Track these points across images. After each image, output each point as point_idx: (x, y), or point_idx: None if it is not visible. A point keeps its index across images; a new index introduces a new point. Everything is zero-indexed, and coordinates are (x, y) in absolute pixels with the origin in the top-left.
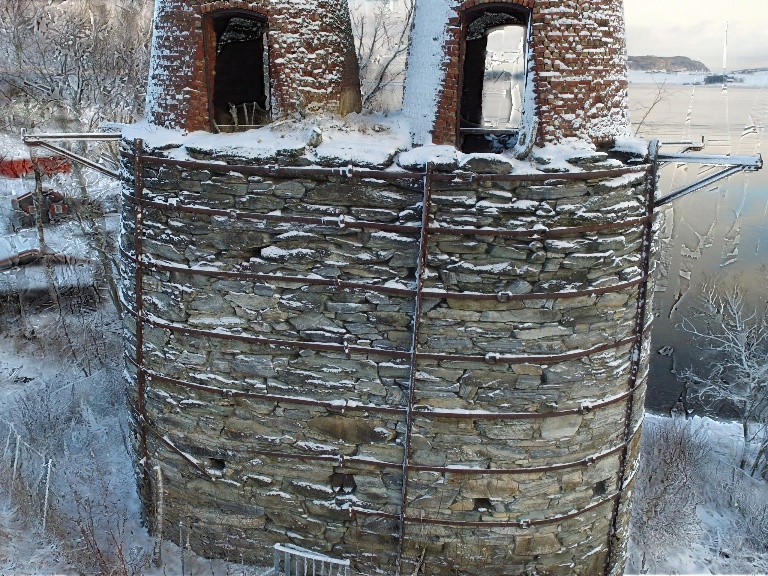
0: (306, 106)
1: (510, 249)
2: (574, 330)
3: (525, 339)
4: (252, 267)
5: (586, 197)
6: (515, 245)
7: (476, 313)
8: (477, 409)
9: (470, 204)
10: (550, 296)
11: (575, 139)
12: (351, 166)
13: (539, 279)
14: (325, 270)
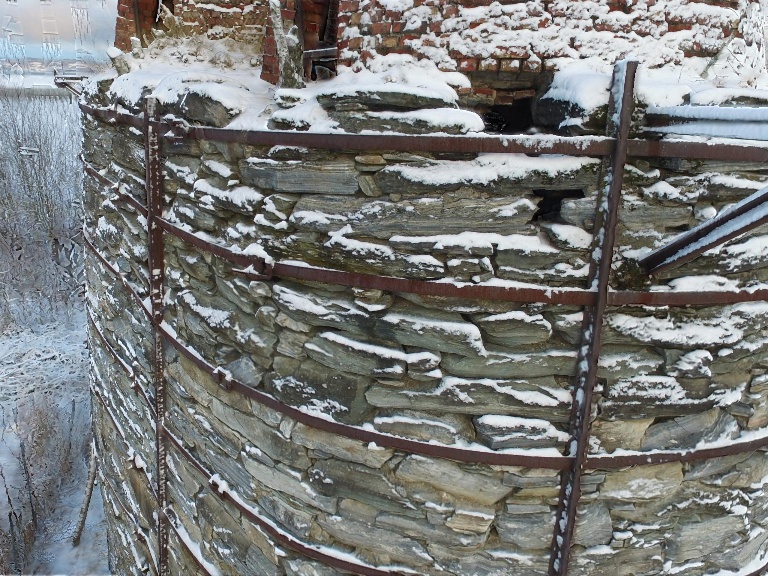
0: (205, 32)
1: (228, 286)
2: (339, 506)
3: (255, 478)
4: (96, 240)
5: (361, 200)
6: (235, 280)
7: (205, 392)
8: (212, 563)
9: (189, 183)
10: (285, 409)
11: (406, 59)
12: (114, 105)
13: (272, 365)
14: (121, 261)
